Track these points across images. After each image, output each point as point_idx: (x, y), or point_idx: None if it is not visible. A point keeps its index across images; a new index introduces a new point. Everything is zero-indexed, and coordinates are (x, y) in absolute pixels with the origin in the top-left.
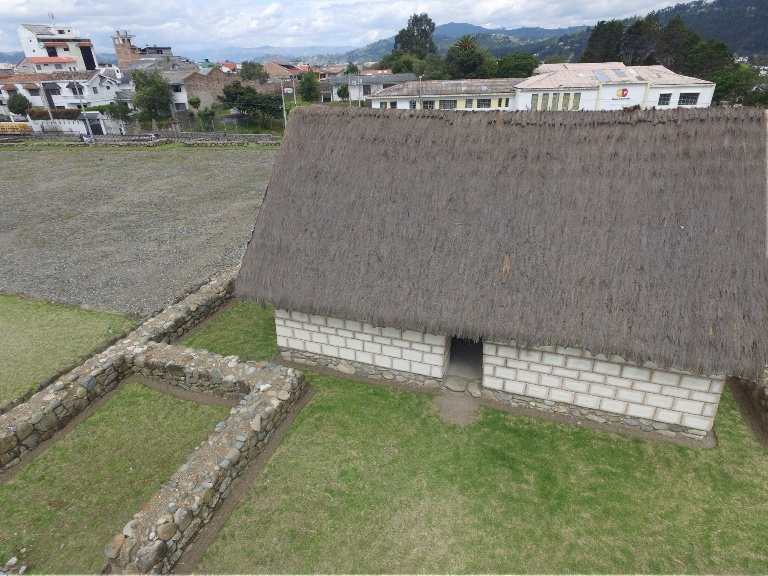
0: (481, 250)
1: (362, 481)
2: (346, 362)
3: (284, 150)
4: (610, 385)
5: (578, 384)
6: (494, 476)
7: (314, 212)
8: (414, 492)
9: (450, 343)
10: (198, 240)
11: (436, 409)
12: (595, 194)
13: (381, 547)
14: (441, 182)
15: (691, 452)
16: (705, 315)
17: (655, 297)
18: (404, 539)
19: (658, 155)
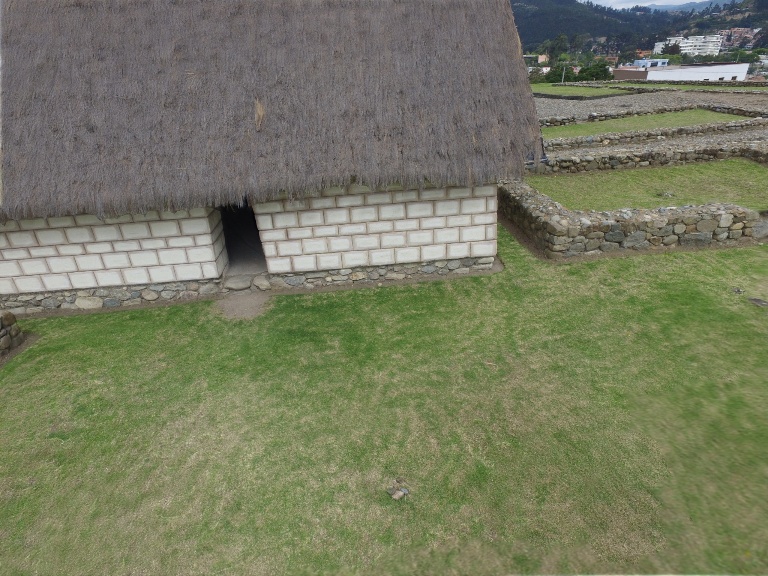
0: (225, 99)
1: (113, 408)
2: (86, 293)
3: None
4: (399, 231)
5: (368, 239)
6: (293, 353)
7: None
8: (190, 397)
9: (223, 238)
10: None
11: (217, 312)
12: (341, 27)
13: (142, 468)
14: (160, 30)
15: (484, 278)
16: (466, 126)
17: (418, 118)
18: (177, 449)
19: None
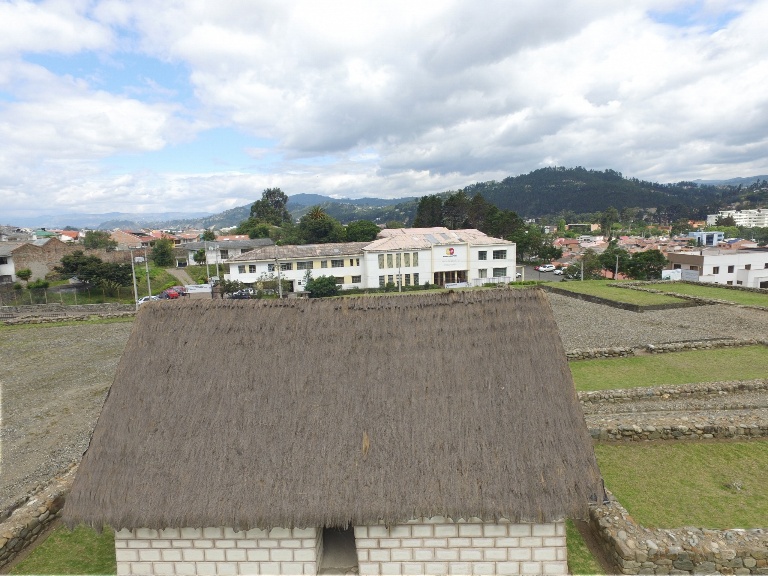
0: (340, 429)
1: None
2: None
3: (132, 345)
4: (476, 547)
5: (449, 552)
6: None
7: (165, 409)
8: None
9: (321, 530)
10: (14, 445)
11: None
12: (431, 365)
13: None
14: (297, 366)
15: None
16: (535, 465)
17: (494, 454)
18: None
19: (473, 329)
